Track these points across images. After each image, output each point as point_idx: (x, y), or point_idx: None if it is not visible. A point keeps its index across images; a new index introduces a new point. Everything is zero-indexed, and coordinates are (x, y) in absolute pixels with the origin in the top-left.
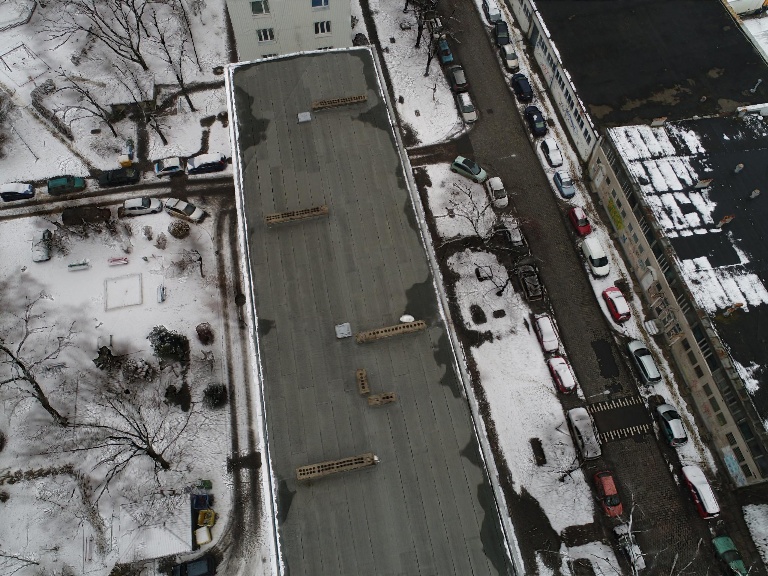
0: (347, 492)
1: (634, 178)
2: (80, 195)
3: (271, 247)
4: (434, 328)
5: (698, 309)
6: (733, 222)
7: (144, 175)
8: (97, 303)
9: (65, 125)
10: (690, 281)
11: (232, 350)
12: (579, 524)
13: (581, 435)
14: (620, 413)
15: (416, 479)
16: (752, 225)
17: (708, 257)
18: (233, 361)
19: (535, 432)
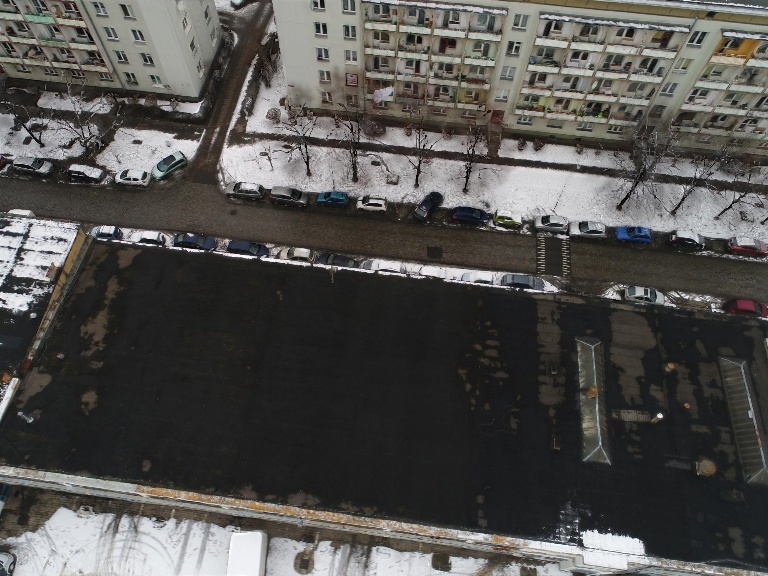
0: None
1: (10, 217)
2: None
3: None
4: None
5: None
6: None
7: None
8: None
9: None
10: None
11: None
12: None
13: None
14: None
15: None
16: None
17: None
18: None
19: None
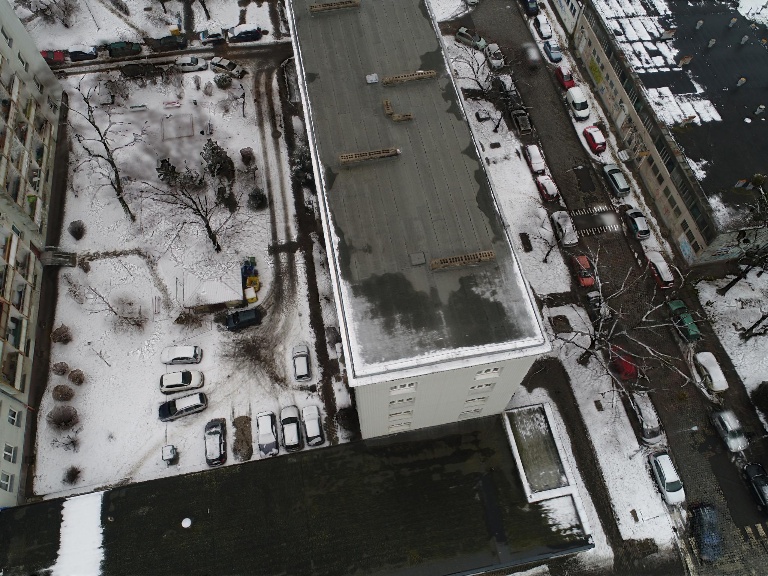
0: (377, 173)
1: (610, 30)
2: (136, 57)
3: (314, 29)
4: (442, 79)
5: (659, 122)
6: (692, 63)
7: (191, 43)
8: (155, 135)
9: (122, 1)
10: (653, 103)
11: (270, 170)
12: (558, 292)
13: (562, 227)
14: (595, 216)
15: (428, 166)
16: (708, 66)
17: (670, 87)
18: (271, 178)
19: (524, 229)
